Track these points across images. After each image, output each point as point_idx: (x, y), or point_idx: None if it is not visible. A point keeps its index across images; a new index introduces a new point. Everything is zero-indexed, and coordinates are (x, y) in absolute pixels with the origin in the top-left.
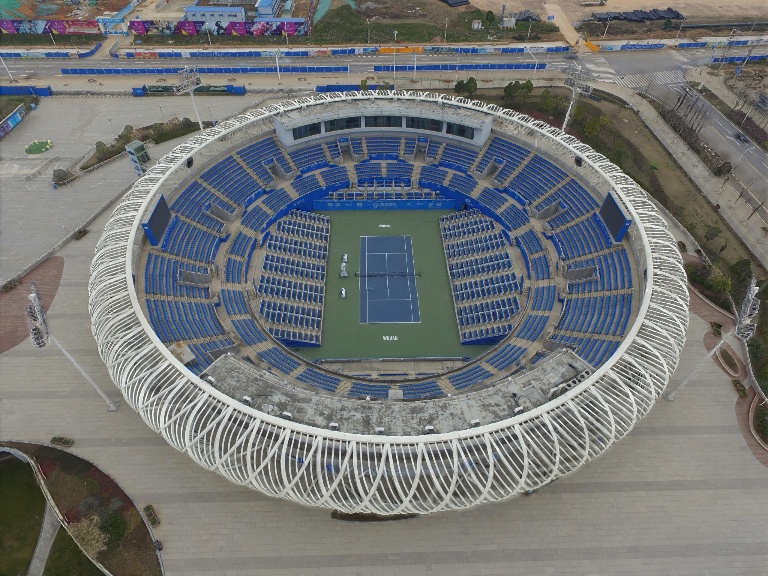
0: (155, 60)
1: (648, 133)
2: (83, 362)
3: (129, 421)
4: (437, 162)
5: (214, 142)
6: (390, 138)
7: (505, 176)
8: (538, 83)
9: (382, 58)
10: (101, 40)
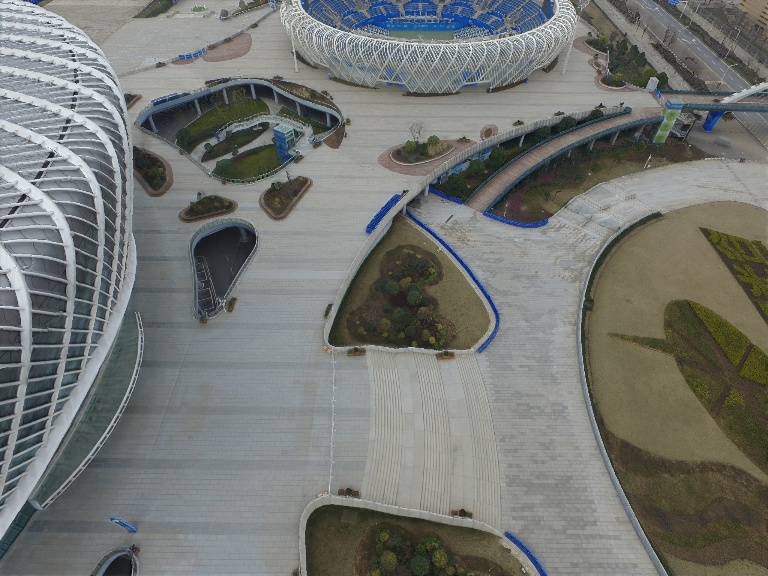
0: None
1: (594, 5)
2: (276, 61)
3: (306, 75)
4: (453, 2)
5: None
6: None
7: (493, 6)
8: None
9: None
10: None
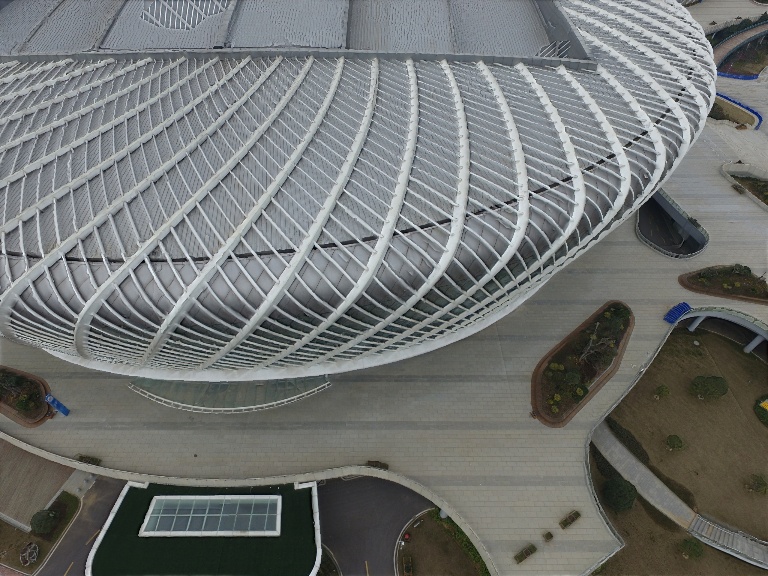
0: None
1: None
2: None
3: None
4: None
5: None
6: None
7: None
8: None
9: None
10: None
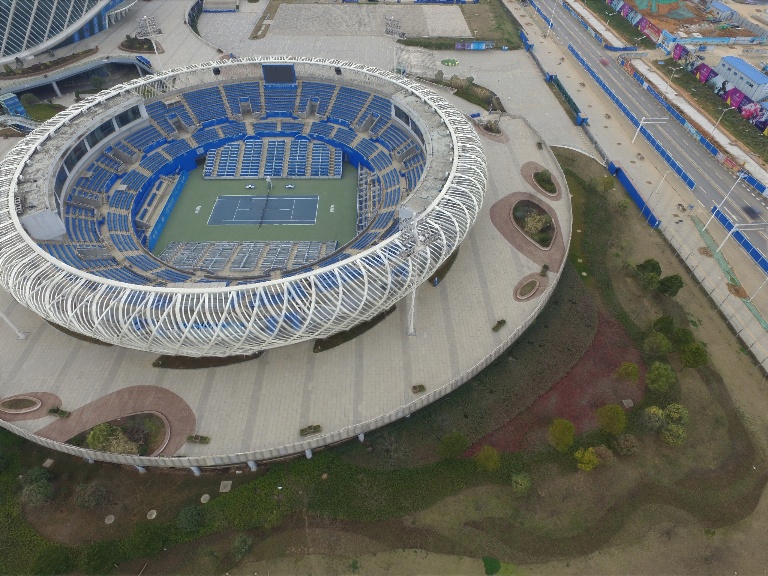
0: (627, 76)
1: None
2: None
3: None
4: None
5: None
6: None
7: None
8: None
9: None
10: (648, 48)
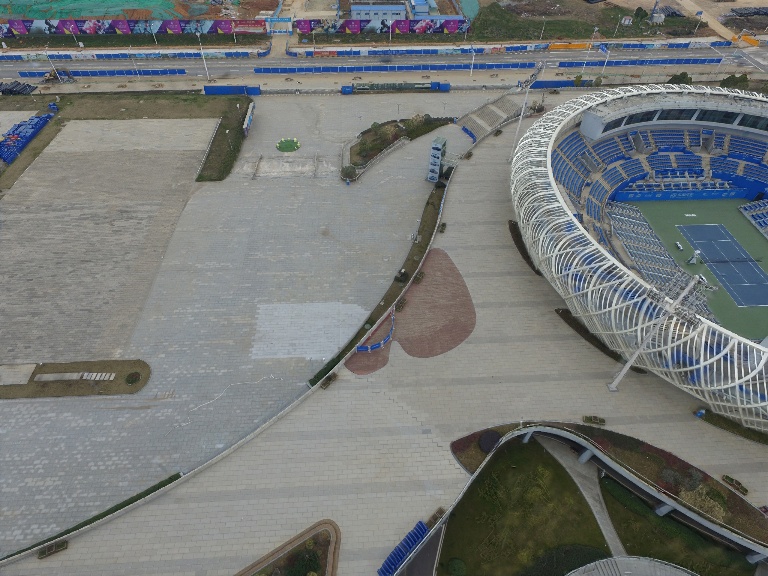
0: (334, 58)
1: None
2: (548, 347)
3: (638, 400)
4: (726, 153)
5: None
6: (673, 131)
7: None
8: (724, 77)
9: (555, 54)
10: (267, 39)
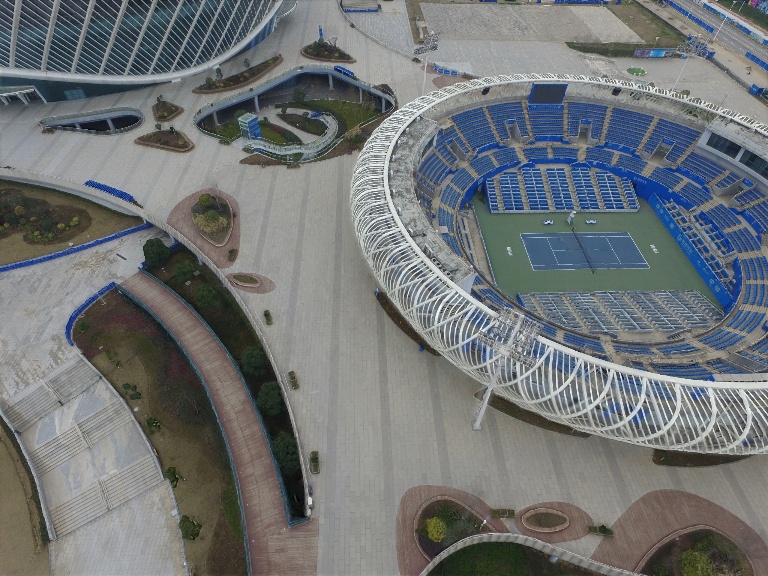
0: None
1: None
2: None
3: None
4: None
5: (665, 106)
6: None
7: None
8: None
9: None
10: None
